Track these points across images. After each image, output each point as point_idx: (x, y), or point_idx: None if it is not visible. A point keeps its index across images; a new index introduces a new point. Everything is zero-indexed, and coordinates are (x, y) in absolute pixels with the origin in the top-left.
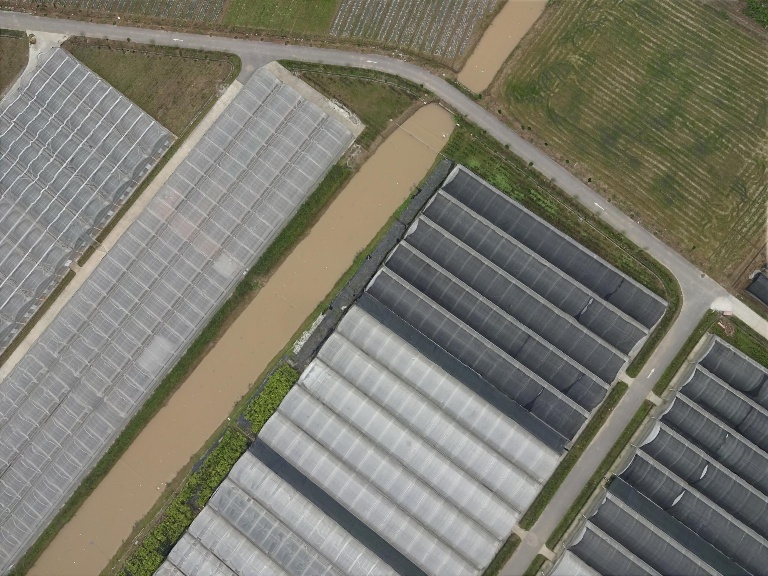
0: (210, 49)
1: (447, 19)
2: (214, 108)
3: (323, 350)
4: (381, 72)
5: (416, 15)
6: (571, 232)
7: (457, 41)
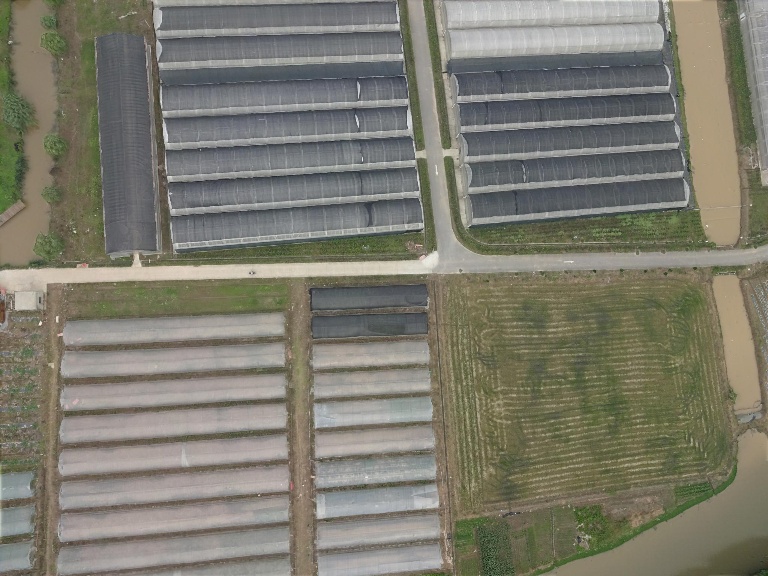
0: None
1: None
2: None
3: (656, 0)
4: None
5: None
6: (570, 226)
7: (763, 303)
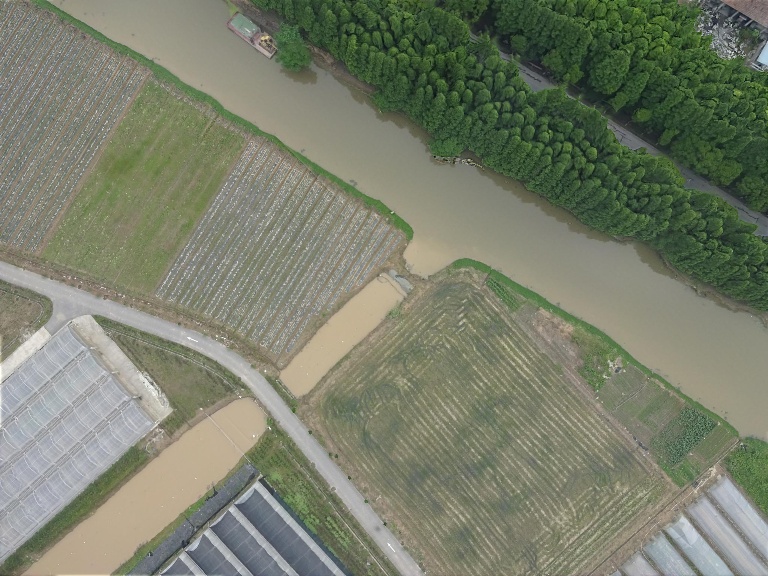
0: (21, 285)
1: (281, 308)
2: (14, 354)
3: None
4: (200, 354)
5: (250, 295)
6: (358, 569)
7: (287, 336)
